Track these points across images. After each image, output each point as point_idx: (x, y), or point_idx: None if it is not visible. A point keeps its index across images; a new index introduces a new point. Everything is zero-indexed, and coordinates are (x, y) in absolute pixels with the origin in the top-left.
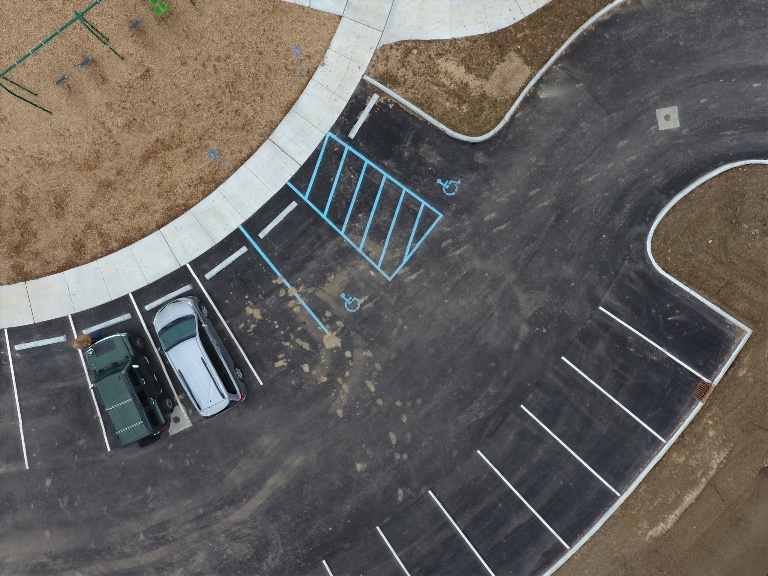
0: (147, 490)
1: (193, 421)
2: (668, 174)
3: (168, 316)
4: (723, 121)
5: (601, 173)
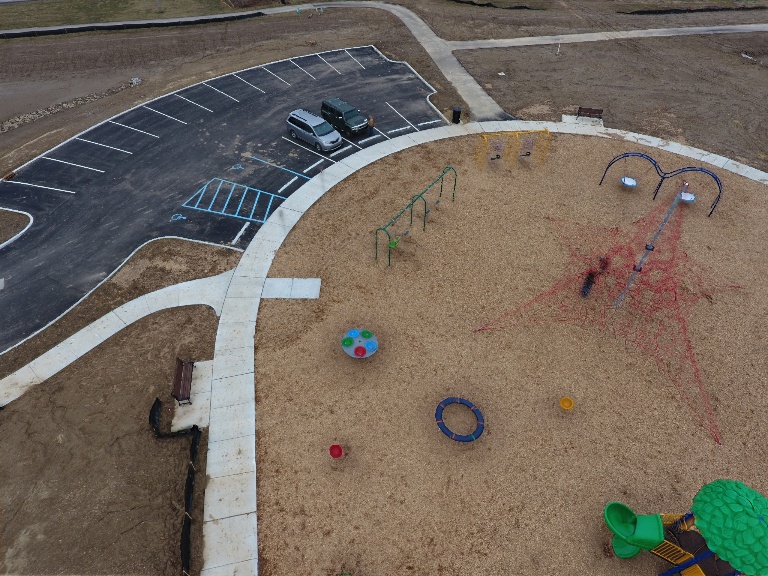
0: None
1: None
2: (4, 258)
3: (332, 135)
4: None
5: (61, 247)
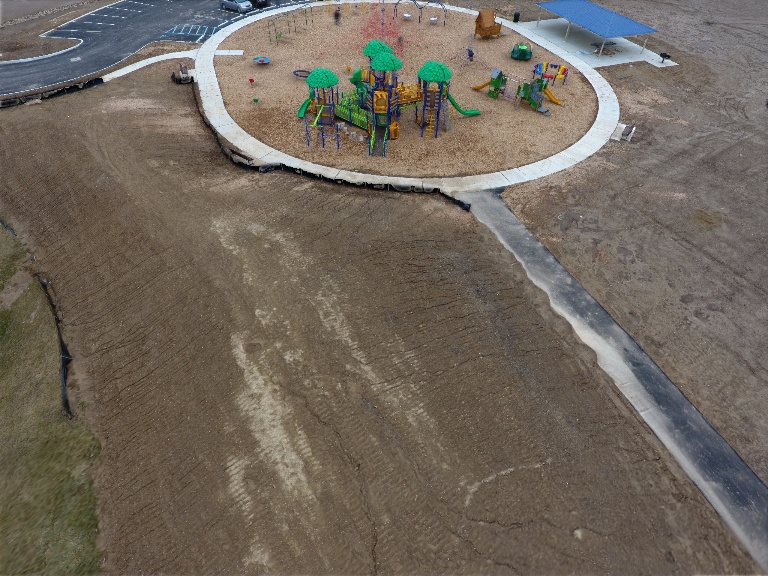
0: None
1: None
2: None
3: None
4: None
5: (104, 47)
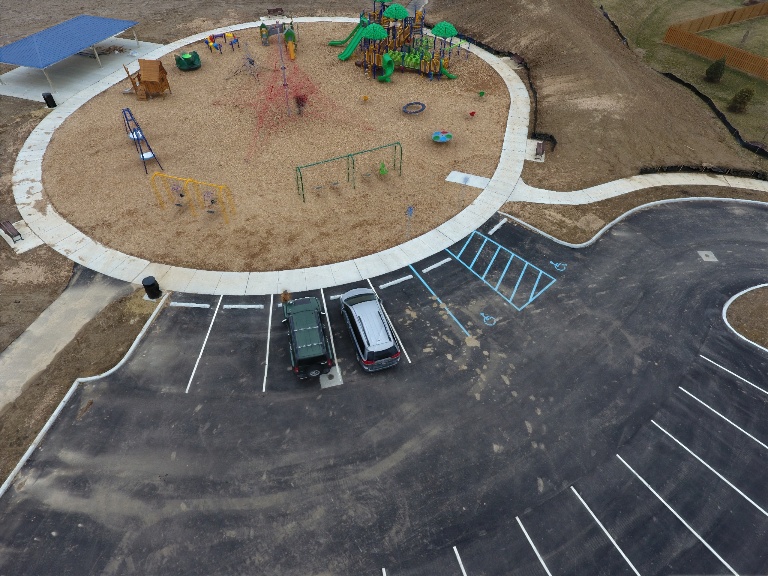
0: (285, 431)
1: (345, 380)
2: (722, 283)
3: (354, 292)
4: (749, 263)
5: (670, 276)
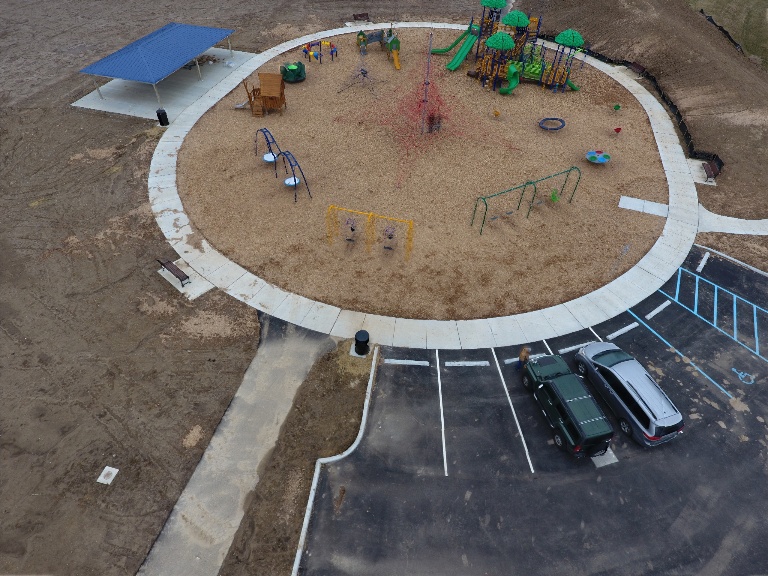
0: (580, 525)
1: (618, 457)
2: None
3: (597, 348)
4: None
5: None
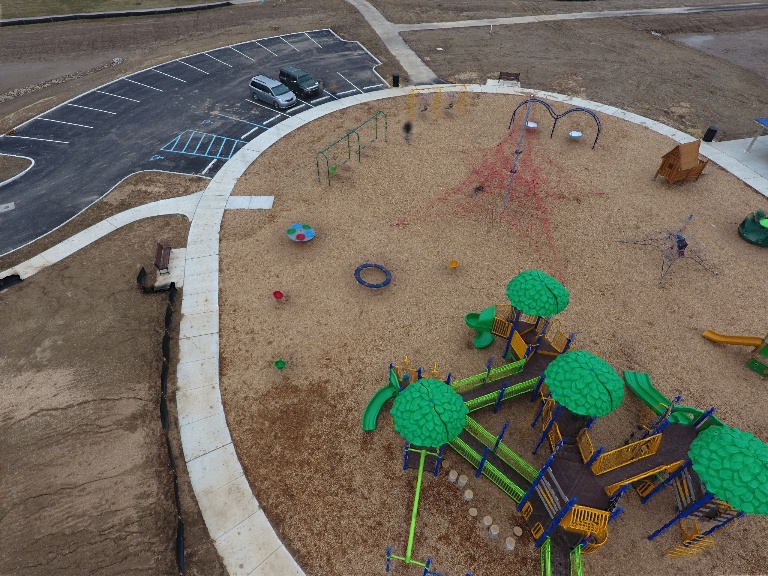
0: None
1: None
2: None
3: (288, 95)
4: None
5: None
